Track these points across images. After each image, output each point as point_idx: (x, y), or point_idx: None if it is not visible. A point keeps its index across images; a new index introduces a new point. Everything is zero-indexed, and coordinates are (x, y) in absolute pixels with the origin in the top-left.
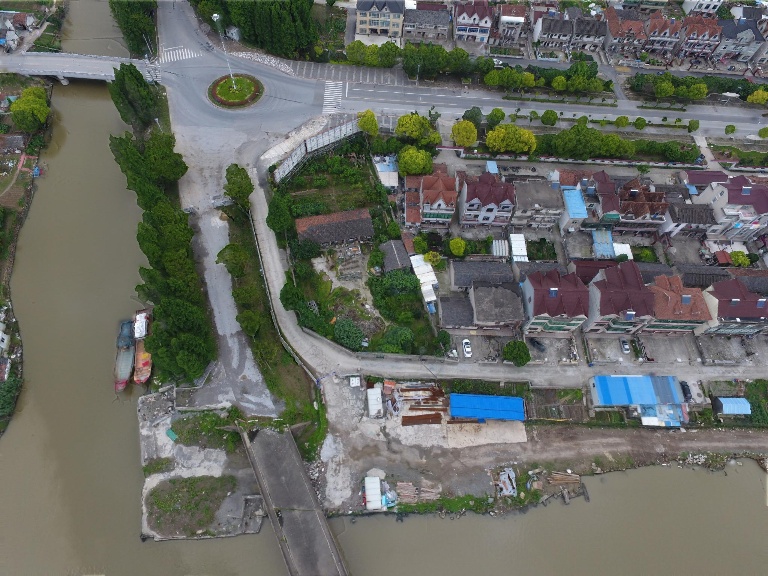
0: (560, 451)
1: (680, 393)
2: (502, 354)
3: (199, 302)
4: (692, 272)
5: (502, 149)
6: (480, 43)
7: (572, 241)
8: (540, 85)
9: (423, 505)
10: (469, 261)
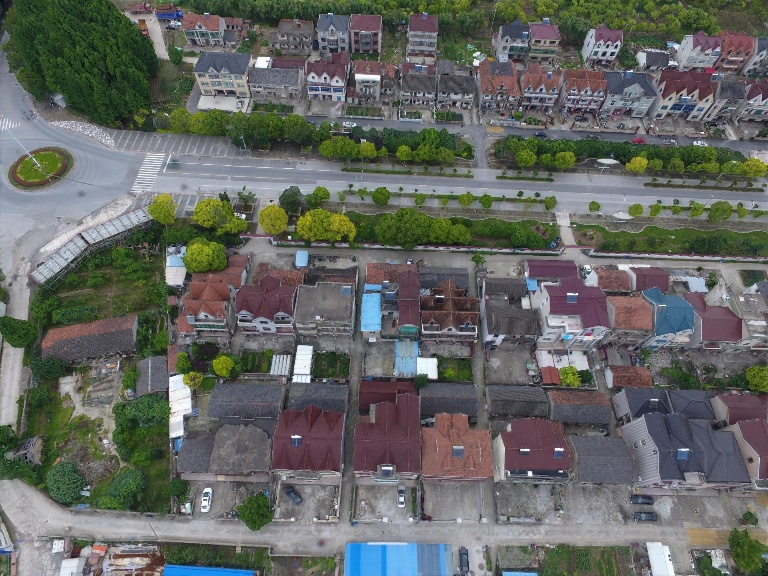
0: None
1: (450, 568)
2: None
3: None
4: (502, 398)
5: (312, 238)
6: (338, 102)
7: (376, 352)
8: (382, 155)
9: None
10: (244, 380)
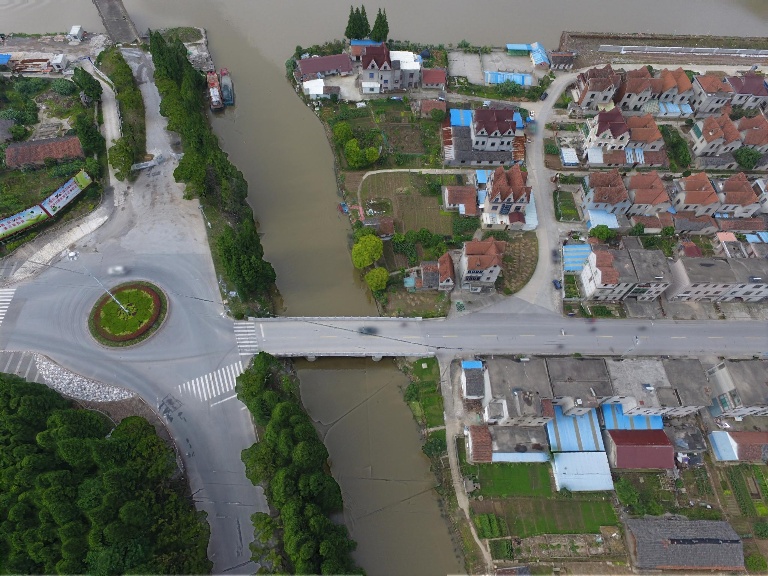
0: None
1: None
2: None
3: None
4: None
5: None
6: None
7: None
8: None
9: (52, 34)
10: None
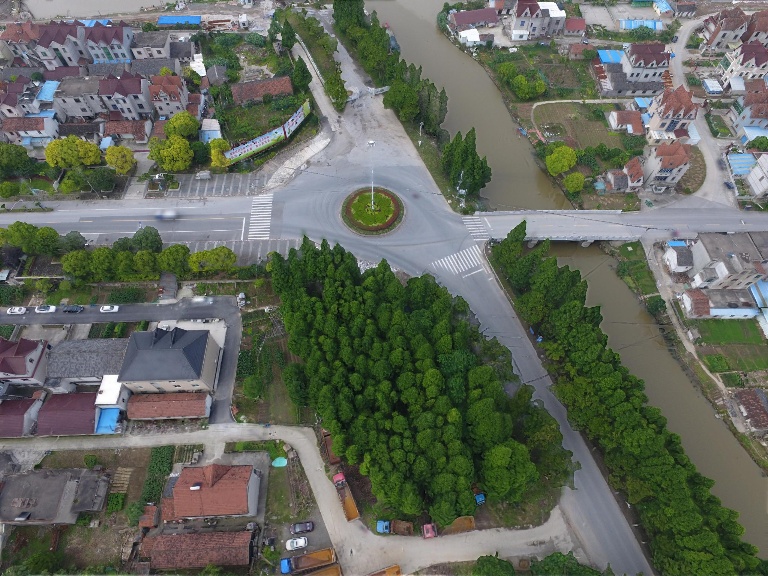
0: (146, 15)
1: None
2: None
3: (351, 45)
4: None
5: None
6: None
7: None
8: None
9: (226, 0)
10: None
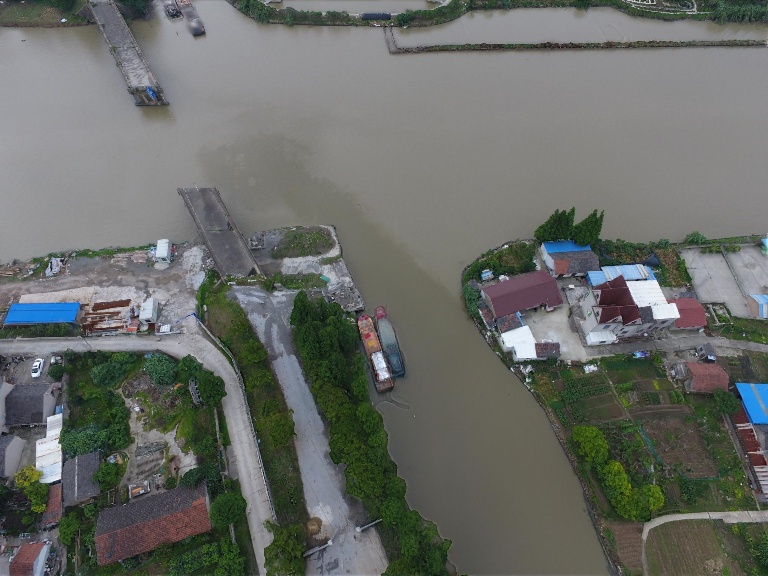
0: None
1: None
2: (2, 364)
3: None
4: None
5: None
6: None
7: None
8: None
9: (129, 250)
10: None
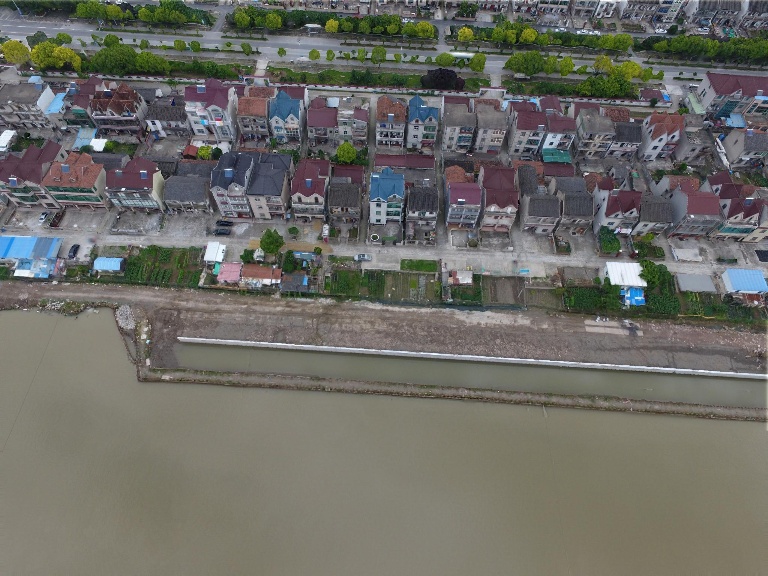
0: None
1: (56, 250)
2: None
3: None
4: None
5: (41, 64)
6: None
7: (69, 139)
8: (126, 17)
9: None
10: None
